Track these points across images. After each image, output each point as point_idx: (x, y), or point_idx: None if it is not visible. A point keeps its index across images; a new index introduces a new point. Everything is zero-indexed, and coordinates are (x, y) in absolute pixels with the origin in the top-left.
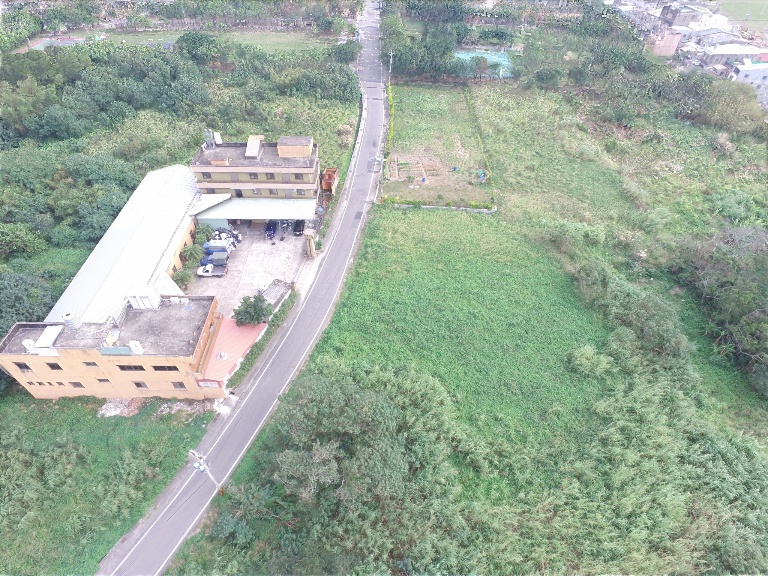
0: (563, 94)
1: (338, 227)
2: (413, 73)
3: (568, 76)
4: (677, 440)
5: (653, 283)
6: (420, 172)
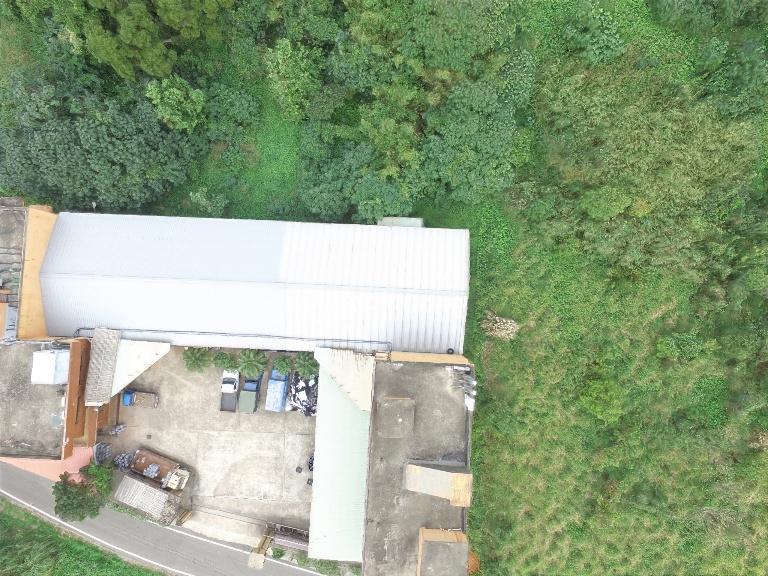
0: None
1: None
2: None
3: None
4: None
5: None
6: None
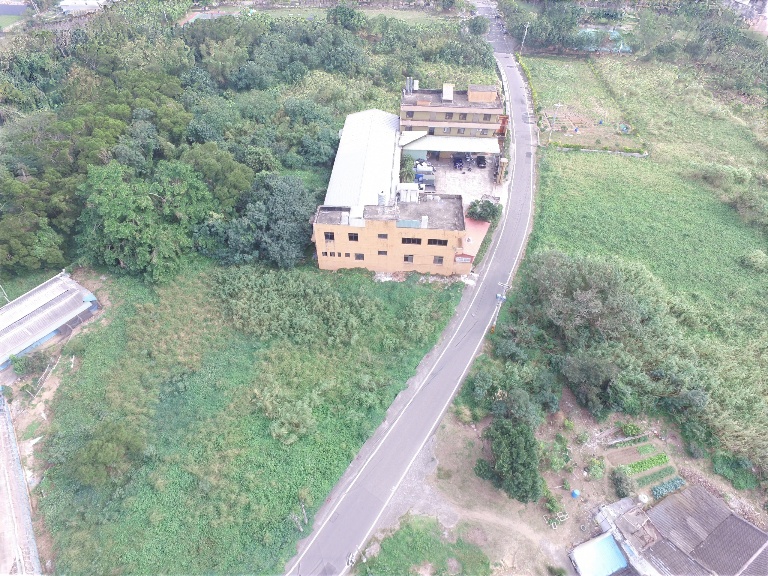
0: (679, 67)
1: (514, 163)
2: (541, 45)
3: (684, 51)
4: None
5: None
6: (569, 125)
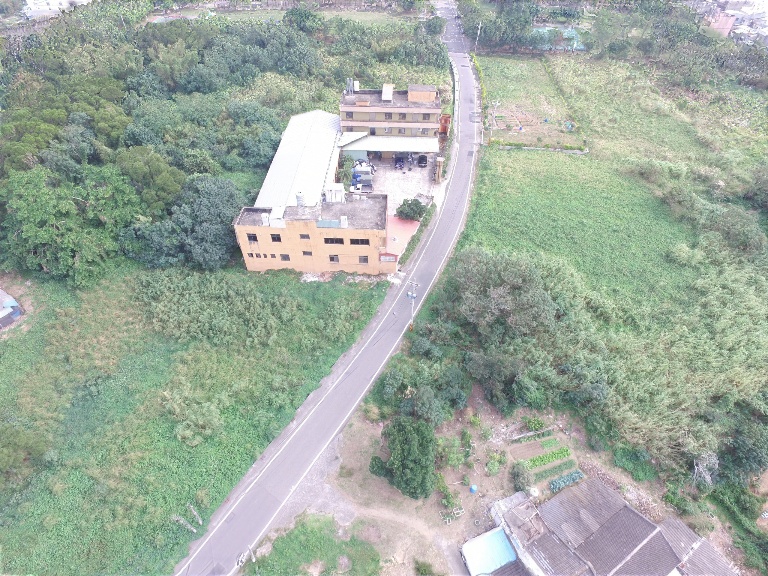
0: (632, 64)
1: (455, 162)
2: (495, 44)
3: (637, 48)
4: (763, 305)
5: (731, 206)
6: (515, 123)
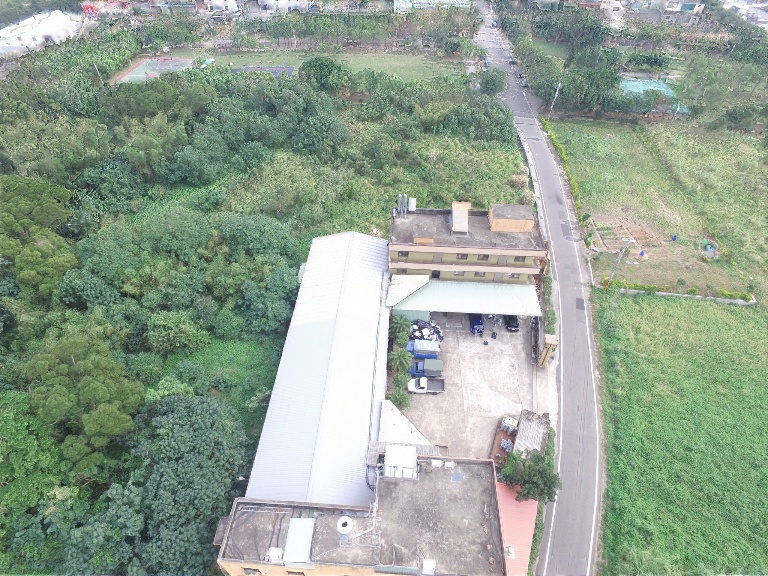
0: (754, 135)
1: (560, 321)
2: (574, 108)
3: (759, 114)
4: None
5: None
6: None
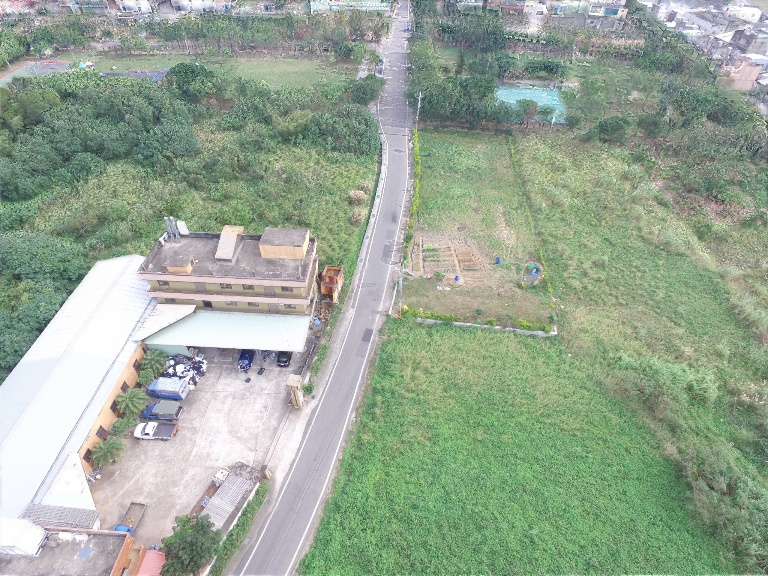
0: (631, 148)
1: (338, 354)
2: (445, 118)
3: (637, 125)
4: None
5: None
6: (452, 263)
